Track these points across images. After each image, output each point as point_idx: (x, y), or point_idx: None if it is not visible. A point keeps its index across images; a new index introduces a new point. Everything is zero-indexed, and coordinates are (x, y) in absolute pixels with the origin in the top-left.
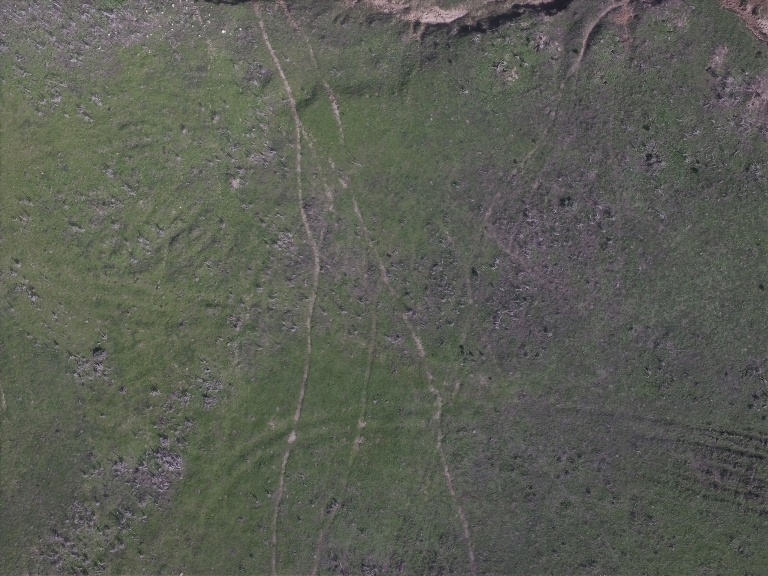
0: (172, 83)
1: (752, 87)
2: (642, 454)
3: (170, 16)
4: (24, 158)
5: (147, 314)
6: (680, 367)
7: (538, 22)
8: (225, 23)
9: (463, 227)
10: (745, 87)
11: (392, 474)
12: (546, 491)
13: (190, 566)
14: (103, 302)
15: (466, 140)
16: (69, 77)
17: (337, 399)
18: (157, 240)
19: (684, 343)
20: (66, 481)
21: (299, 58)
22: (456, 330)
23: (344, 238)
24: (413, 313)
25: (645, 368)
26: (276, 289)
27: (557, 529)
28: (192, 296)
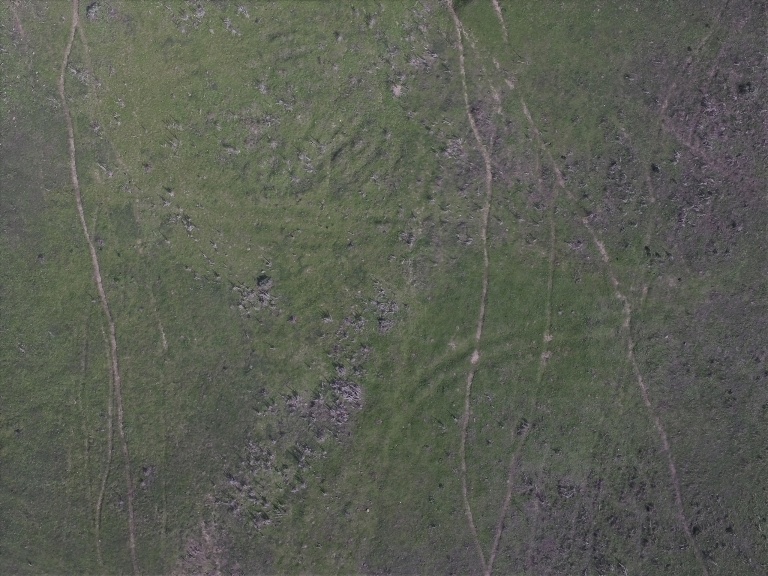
0: None
1: None
2: None
3: None
4: (169, 80)
5: (312, 237)
6: None
7: None
8: None
9: (639, 122)
10: None
11: (583, 388)
12: (746, 394)
13: (376, 501)
14: (264, 227)
15: (636, 30)
16: None
17: (520, 313)
18: (318, 157)
19: None
20: (238, 421)
21: None
22: (640, 231)
23: (515, 142)
24: (594, 216)
25: None
26: (448, 200)
27: (761, 433)
28: (359, 214)
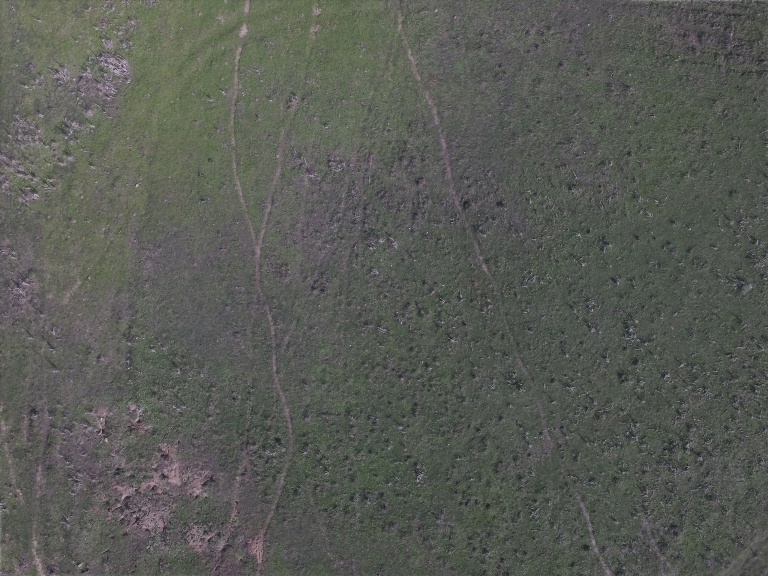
0: None
1: None
2: (615, 21)
3: None
4: None
5: None
6: None
7: None
8: None
9: None
10: None
11: (353, 62)
12: (517, 68)
13: (146, 177)
14: None
15: None
16: None
17: None
18: None
19: None
20: (6, 96)
21: None
22: None
23: None
24: None
25: None
26: None
27: (531, 107)
28: None
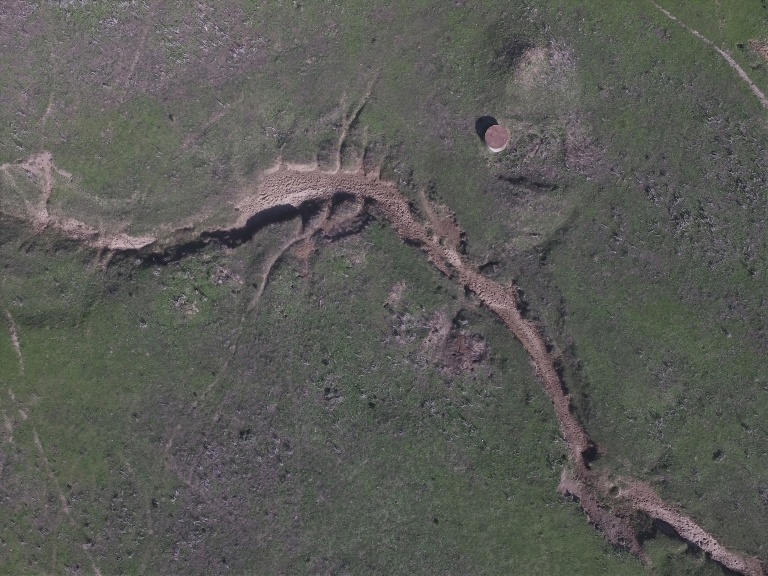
0: None
1: (429, 324)
2: None
3: None
4: None
5: None
6: None
7: (220, 255)
8: None
9: (143, 459)
10: (423, 323)
11: None
12: None
13: None
14: None
15: (146, 373)
16: None
17: None
18: None
19: (360, 575)
20: None
21: None
22: (136, 561)
23: (24, 469)
24: (92, 544)
25: None
26: None
27: None
28: None
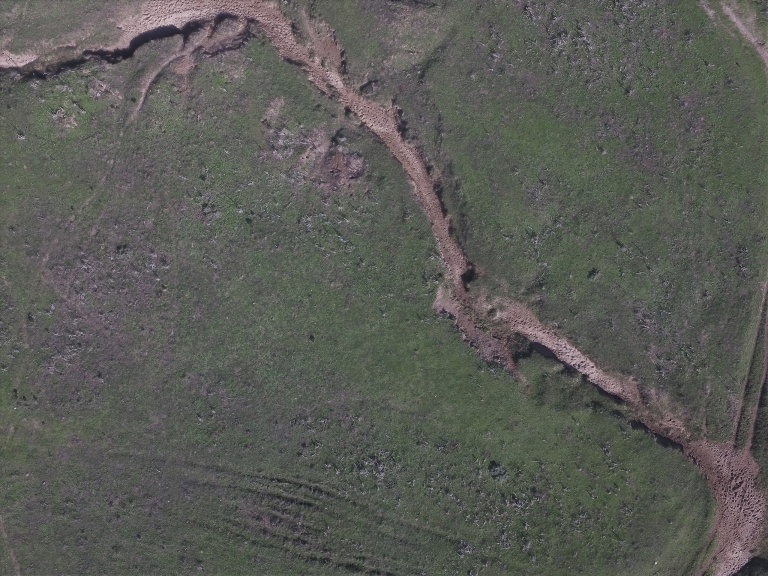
0: None
1: (306, 140)
2: (193, 500)
3: None
4: None
5: None
6: (232, 415)
7: (100, 70)
8: None
9: (20, 272)
10: (302, 140)
11: None
12: (98, 535)
13: None
14: None
15: (24, 186)
16: None
17: None
18: None
19: (236, 391)
20: None
21: None
22: (11, 374)
23: None
24: None
25: (197, 415)
26: None
27: (108, 572)
28: None
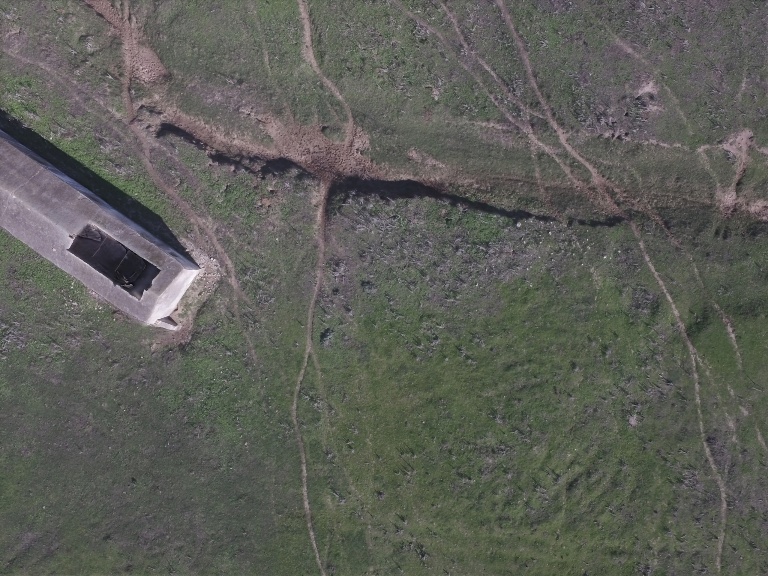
0: (558, 318)
1: None
2: None
3: (549, 245)
4: (403, 407)
5: (547, 566)
6: None
7: None
8: (605, 247)
9: None
10: None
11: None
12: None
13: None
14: (498, 556)
15: None
16: (445, 317)
17: None
18: (554, 487)
19: None
20: None
21: (684, 278)
22: None
23: (750, 469)
24: None
25: None
26: (684, 530)
27: None
28: (594, 544)
